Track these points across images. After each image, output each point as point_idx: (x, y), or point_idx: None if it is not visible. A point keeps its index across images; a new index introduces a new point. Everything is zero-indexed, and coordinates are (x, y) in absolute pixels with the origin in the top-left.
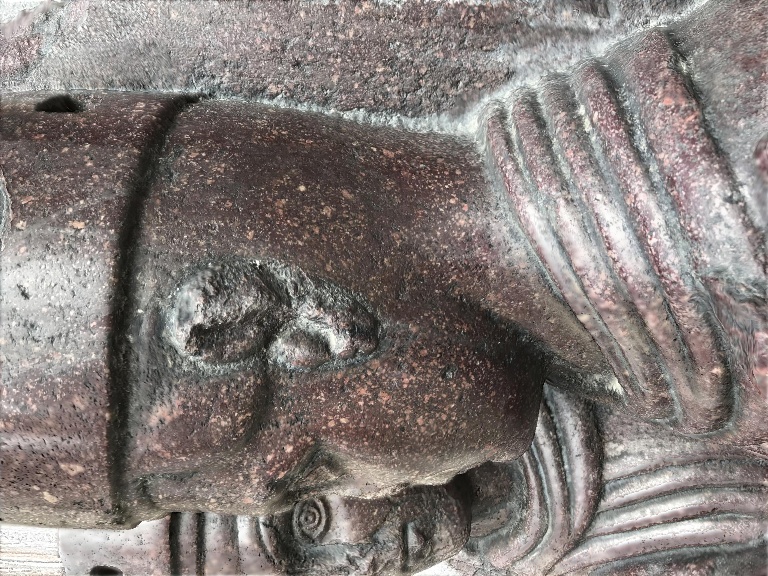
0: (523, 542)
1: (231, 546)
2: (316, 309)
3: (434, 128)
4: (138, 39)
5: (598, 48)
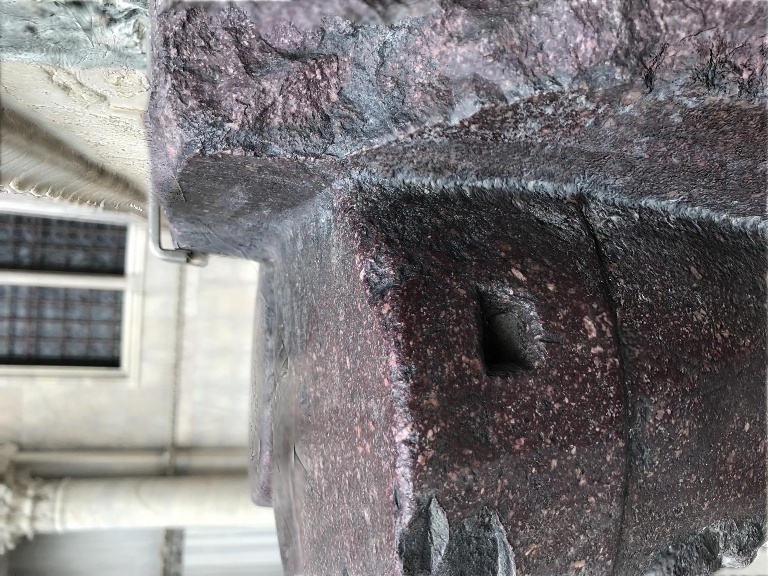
0: None
1: None
2: (738, 555)
3: None
4: (536, 142)
5: None
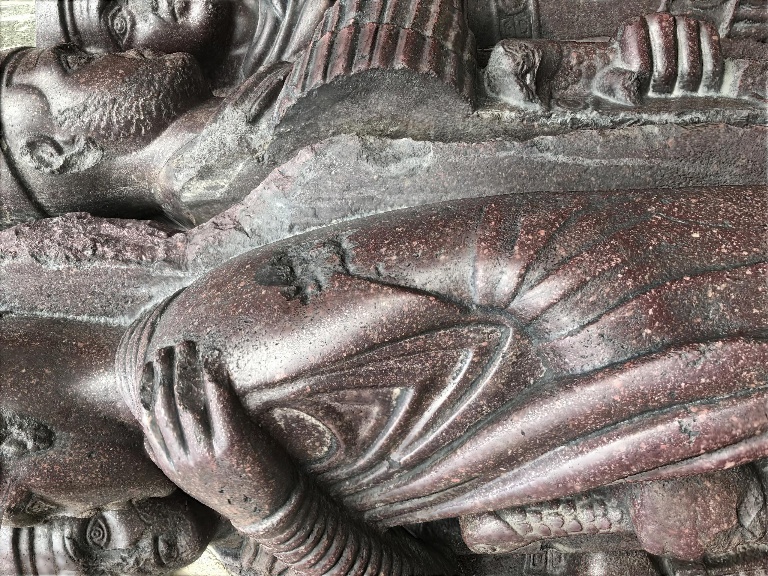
0: (249, 549)
1: (49, 551)
2: (17, 430)
3: (122, 322)
4: None
5: (187, 285)
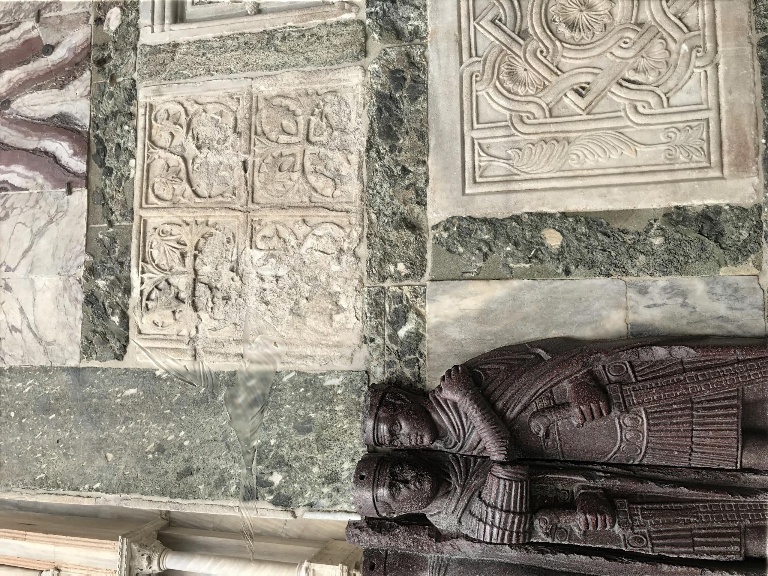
0: None
1: None
2: None
3: (423, 554)
4: None
5: None
